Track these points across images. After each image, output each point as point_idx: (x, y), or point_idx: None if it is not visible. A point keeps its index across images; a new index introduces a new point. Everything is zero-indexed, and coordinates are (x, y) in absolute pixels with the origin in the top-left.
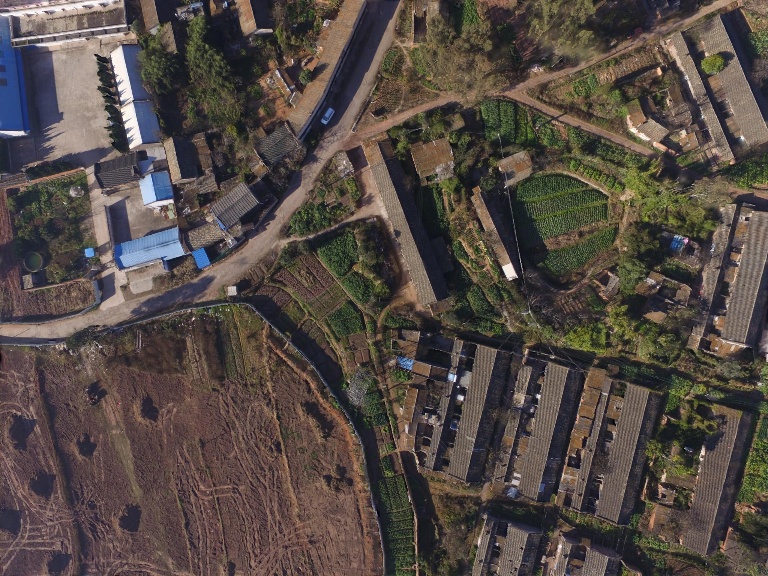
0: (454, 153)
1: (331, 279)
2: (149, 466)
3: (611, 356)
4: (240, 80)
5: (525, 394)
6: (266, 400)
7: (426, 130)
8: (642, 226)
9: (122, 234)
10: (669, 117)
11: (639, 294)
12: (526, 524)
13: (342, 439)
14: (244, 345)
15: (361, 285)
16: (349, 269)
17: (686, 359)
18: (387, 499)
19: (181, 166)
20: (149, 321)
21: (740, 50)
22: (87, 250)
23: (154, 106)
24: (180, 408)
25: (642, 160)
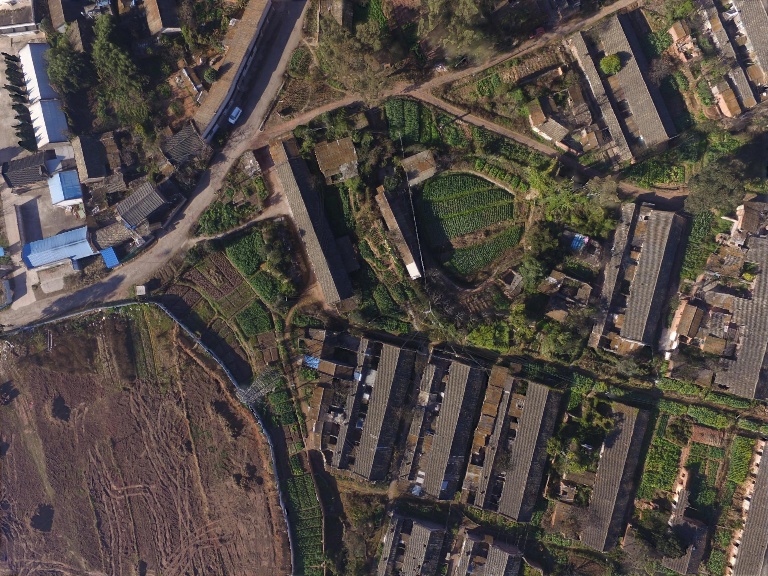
0: (357, 152)
1: (240, 278)
2: (61, 466)
3: (515, 354)
4: (147, 79)
5: (429, 392)
6: (176, 399)
7: (330, 129)
8: (546, 225)
9: (33, 233)
10: (569, 117)
11: (542, 293)
12: (432, 522)
13: (252, 438)
14: (154, 344)
15: (269, 284)
16: (257, 268)
17: (587, 357)
18: (296, 497)
19: (88, 165)
20: (60, 320)
21: (638, 50)
22: None
23: (61, 105)
24: (91, 407)
25: (545, 159)
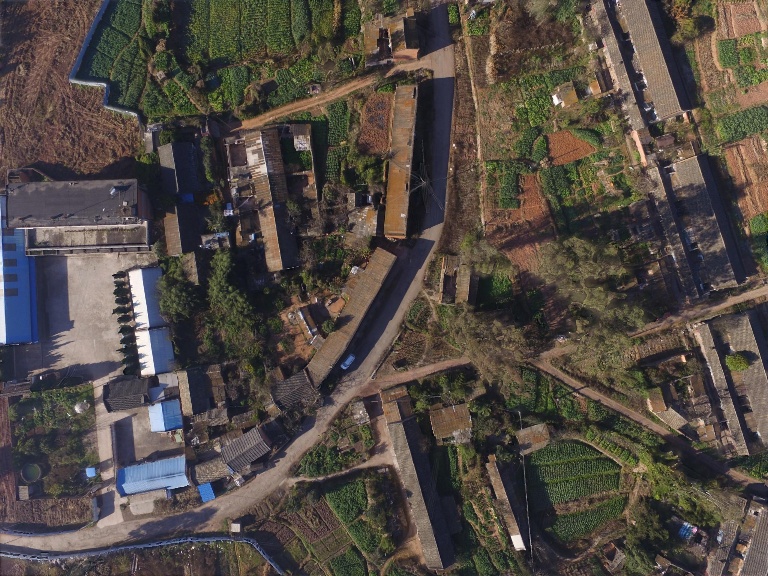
0: (473, 422)
1: (337, 522)
2: None
3: None
4: (261, 317)
5: None
6: None
7: (447, 393)
8: (652, 502)
9: (126, 452)
10: (689, 408)
11: None
12: None
13: None
14: None
15: (367, 535)
16: (356, 516)
17: None
18: None
19: (193, 400)
20: None
21: (765, 349)
22: (88, 469)
23: (170, 334)
24: None
25: (658, 441)
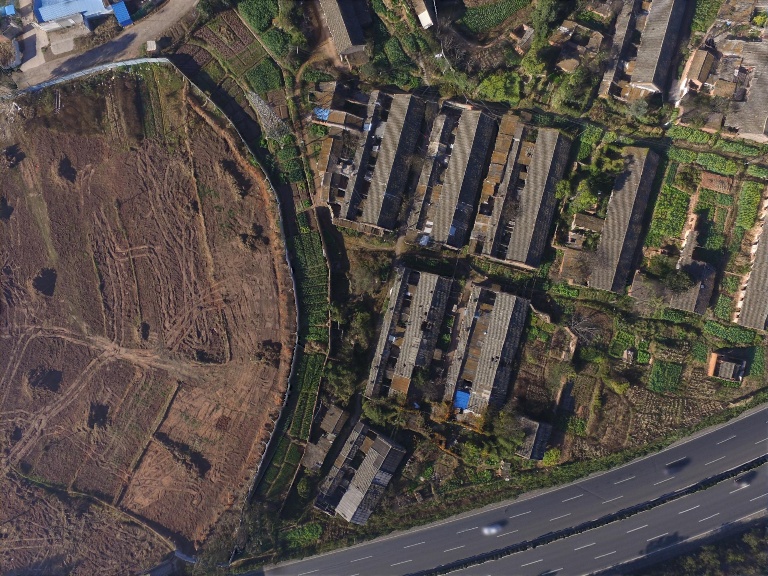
0: None
1: (251, 37)
2: (66, 229)
3: (525, 108)
4: None
5: (439, 141)
6: (184, 159)
7: None
8: None
9: None
10: None
11: (553, 46)
12: None
13: (259, 198)
14: (163, 104)
15: (280, 39)
16: (269, 25)
17: (597, 107)
18: (302, 255)
19: None
20: (69, 81)
21: None
22: (7, 7)
23: None
24: (98, 169)
25: None
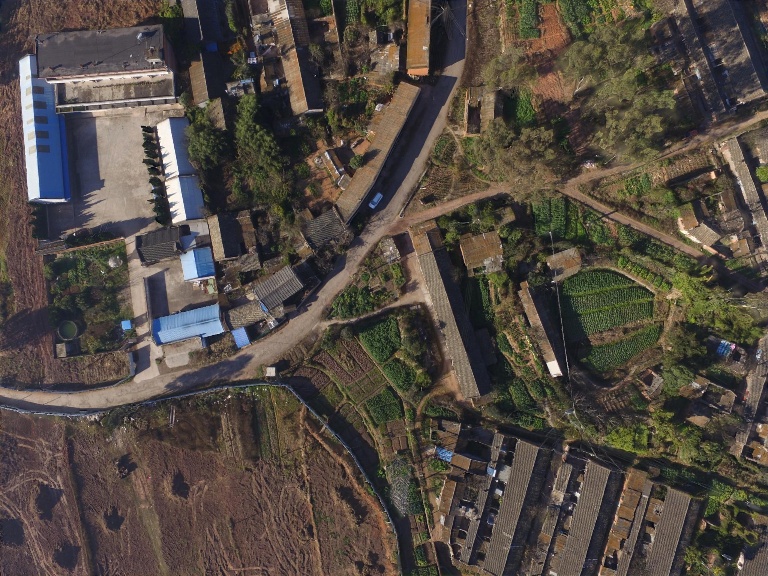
0: (504, 248)
1: (371, 364)
2: (177, 543)
3: (652, 457)
4: (288, 160)
5: (565, 492)
6: (300, 482)
7: (476, 222)
8: (688, 327)
9: (160, 306)
10: (721, 222)
11: (683, 396)
12: None
13: (375, 525)
14: (280, 426)
15: (402, 373)
16: (390, 355)
17: (728, 465)
18: None
19: (225, 244)
20: (184, 396)
21: None
22: (124, 322)
23: (199, 181)
24: (212, 486)
25: (691, 262)
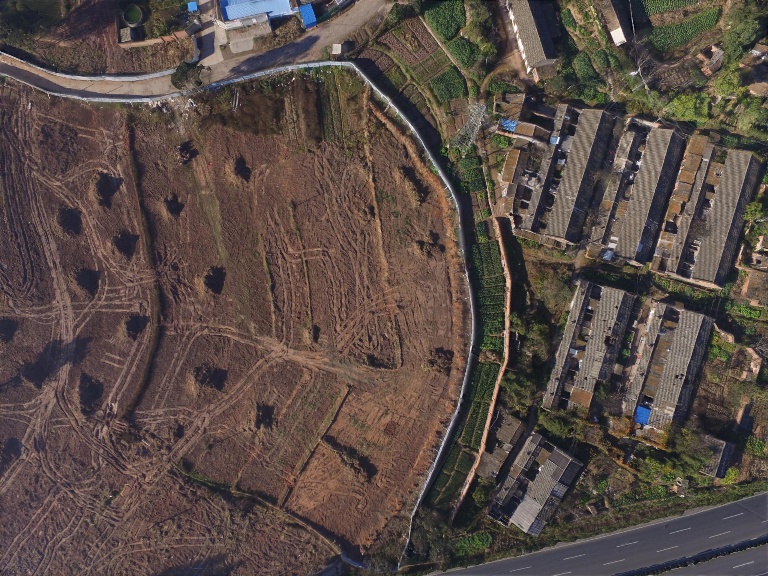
0: None
1: (436, 45)
2: (237, 228)
3: (711, 128)
4: None
5: (627, 158)
6: (362, 163)
7: None
8: None
9: None
10: None
11: (742, 68)
12: None
13: (437, 205)
14: (343, 108)
15: (467, 49)
16: (455, 34)
17: None
18: (480, 264)
19: None
20: (248, 80)
21: None
22: (190, 3)
23: None
24: (273, 169)
25: None
